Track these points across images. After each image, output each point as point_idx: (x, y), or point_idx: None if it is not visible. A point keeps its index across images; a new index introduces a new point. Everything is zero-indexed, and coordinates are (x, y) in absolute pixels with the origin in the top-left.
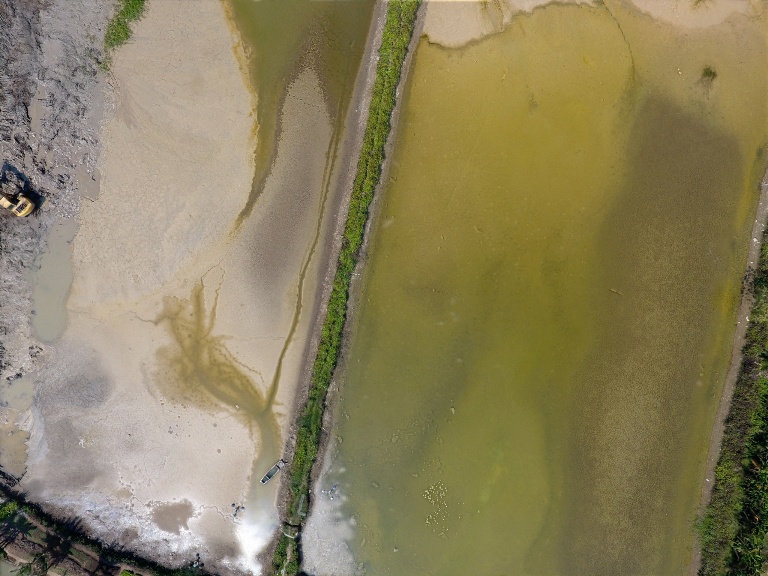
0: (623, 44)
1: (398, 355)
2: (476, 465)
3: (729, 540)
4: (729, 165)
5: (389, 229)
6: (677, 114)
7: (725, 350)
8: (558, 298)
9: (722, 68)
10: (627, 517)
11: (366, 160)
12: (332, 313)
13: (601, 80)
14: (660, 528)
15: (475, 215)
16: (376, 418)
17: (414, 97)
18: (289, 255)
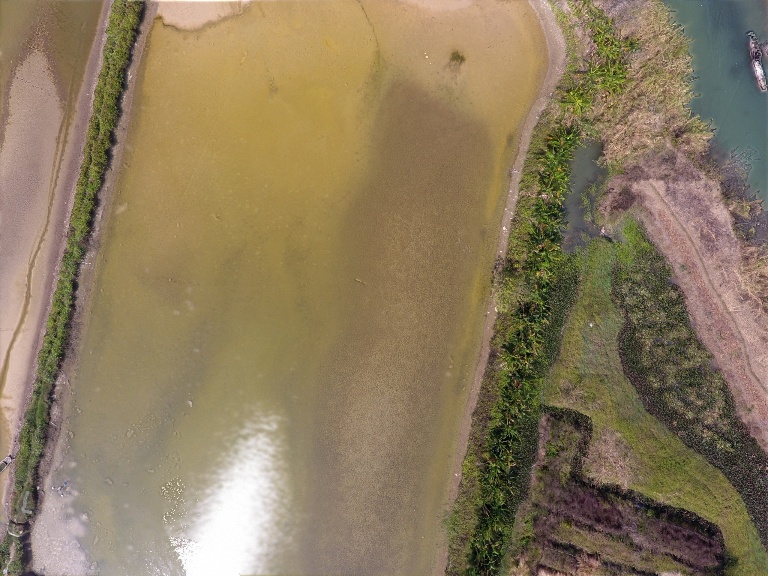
0: (367, 27)
1: (133, 347)
2: (216, 460)
3: (470, 536)
4: (478, 152)
5: (123, 217)
6: (424, 99)
7: (475, 341)
8: (301, 288)
9: (470, 52)
10: (373, 513)
11: (90, 145)
12: (56, 303)
13: (344, 64)
14: (408, 524)
15: (213, 202)
16: (110, 412)
17: (148, 81)
18: (17, 243)
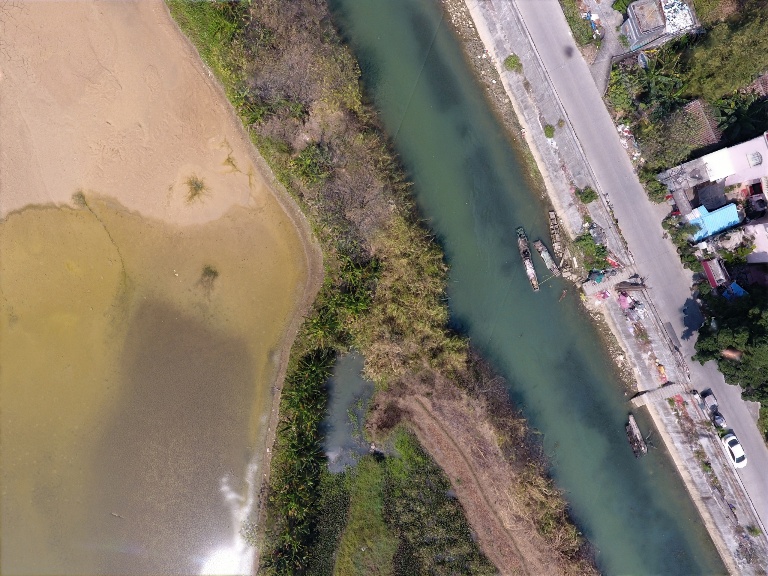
0: (111, 247)
1: None
2: None
3: None
4: (237, 370)
5: None
6: (175, 319)
7: (244, 570)
8: (53, 526)
9: (223, 267)
10: None
11: None
12: None
13: (88, 287)
14: None
15: None
16: None
17: None
18: None
